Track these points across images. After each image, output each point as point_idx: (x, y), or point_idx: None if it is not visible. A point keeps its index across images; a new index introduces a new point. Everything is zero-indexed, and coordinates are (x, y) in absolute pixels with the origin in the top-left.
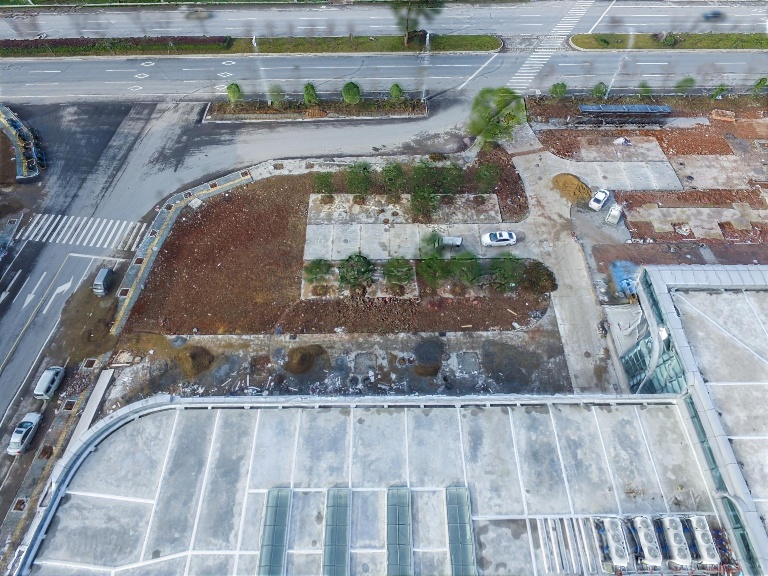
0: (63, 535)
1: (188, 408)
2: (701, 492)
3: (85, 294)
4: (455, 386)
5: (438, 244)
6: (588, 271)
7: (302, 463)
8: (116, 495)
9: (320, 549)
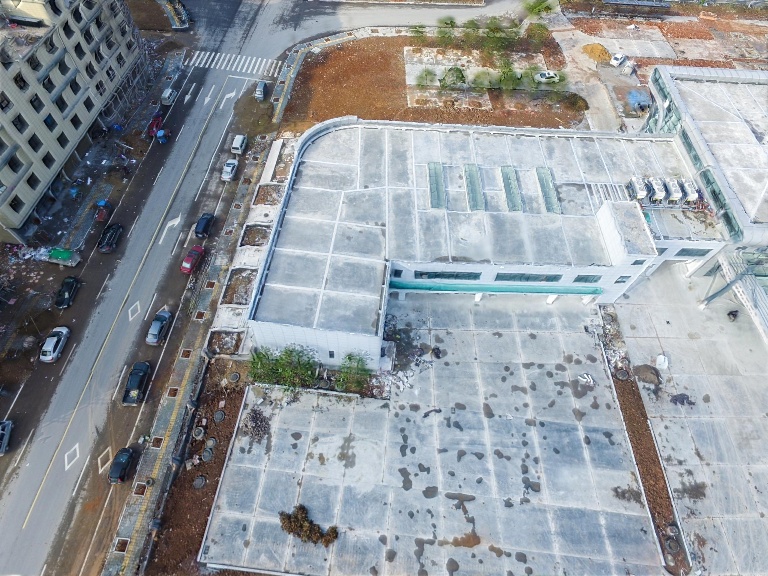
0: (307, 177)
1: (366, 128)
2: None
3: (247, 99)
4: None
5: (504, 77)
6: (610, 100)
7: (445, 154)
8: (333, 162)
9: (464, 189)
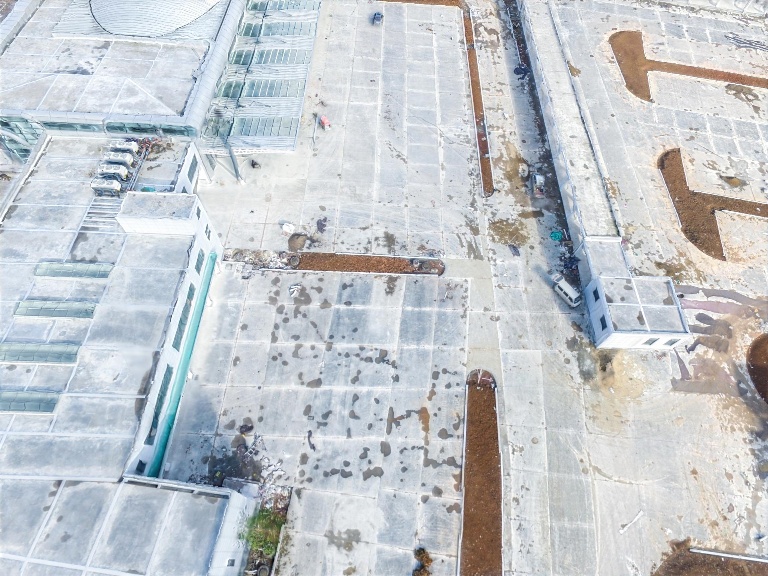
0: None
1: None
2: (107, 142)
3: None
4: None
5: None
6: None
7: None
8: None
9: (35, 366)
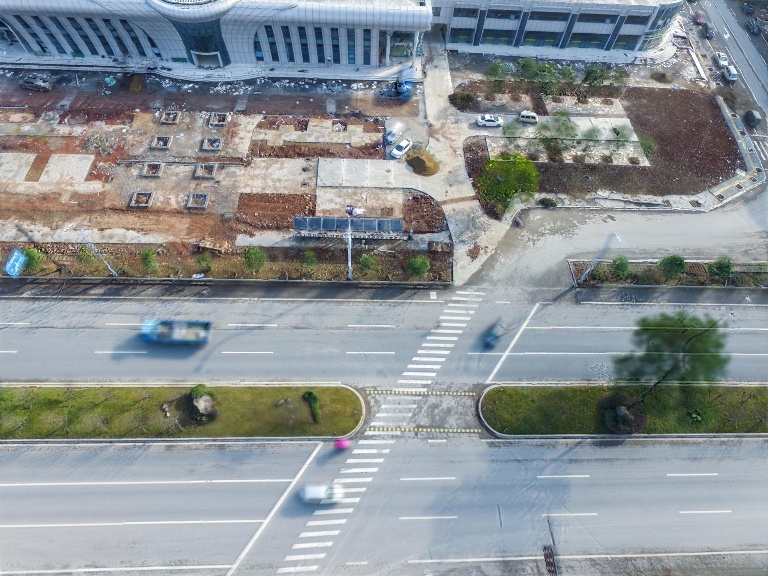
0: None
1: None
2: None
3: None
4: (512, 60)
5: None
6: None
7: None
8: None
9: None
